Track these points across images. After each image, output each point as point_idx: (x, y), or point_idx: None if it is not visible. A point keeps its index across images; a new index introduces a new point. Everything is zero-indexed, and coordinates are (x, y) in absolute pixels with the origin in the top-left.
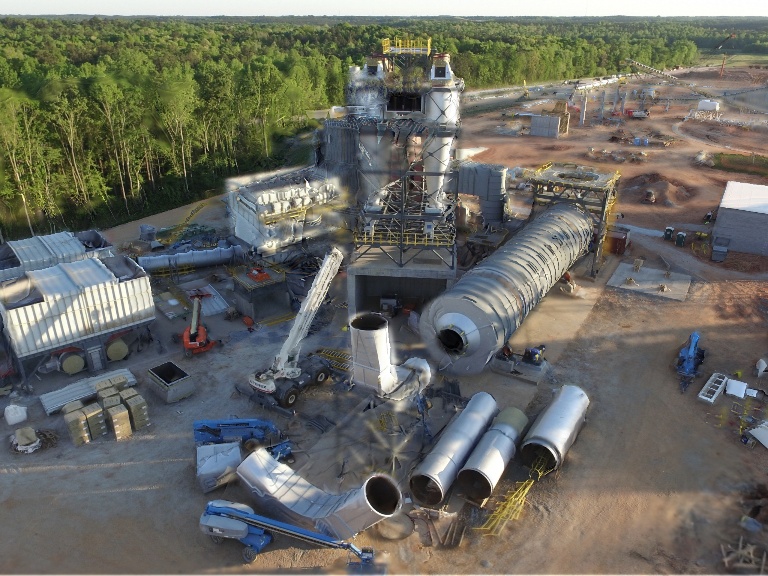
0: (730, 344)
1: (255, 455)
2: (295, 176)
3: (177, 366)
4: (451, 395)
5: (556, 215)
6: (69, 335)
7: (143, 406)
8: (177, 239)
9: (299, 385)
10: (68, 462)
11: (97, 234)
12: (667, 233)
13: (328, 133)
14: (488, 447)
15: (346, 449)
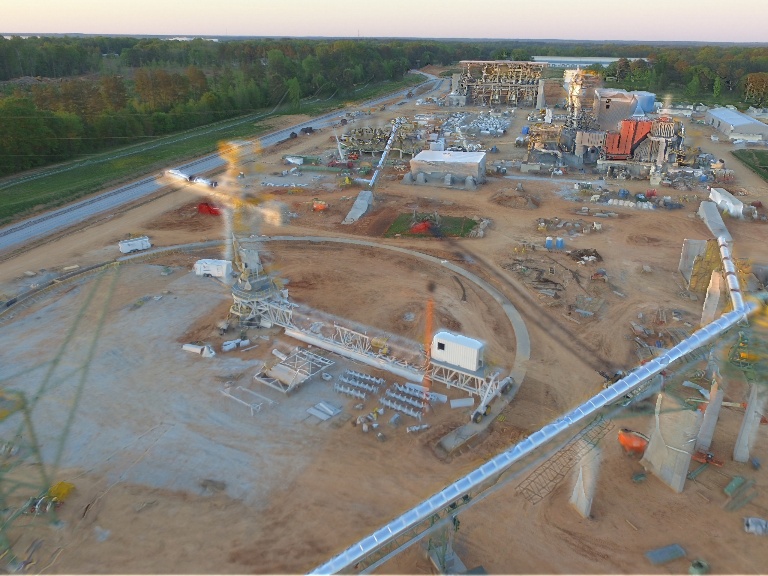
0: None
1: None
2: None
3: None
4: None
5: None
6: None
7: None
8: None
9: None
10: None
11: None
12: None
13: None
14: None
15: None
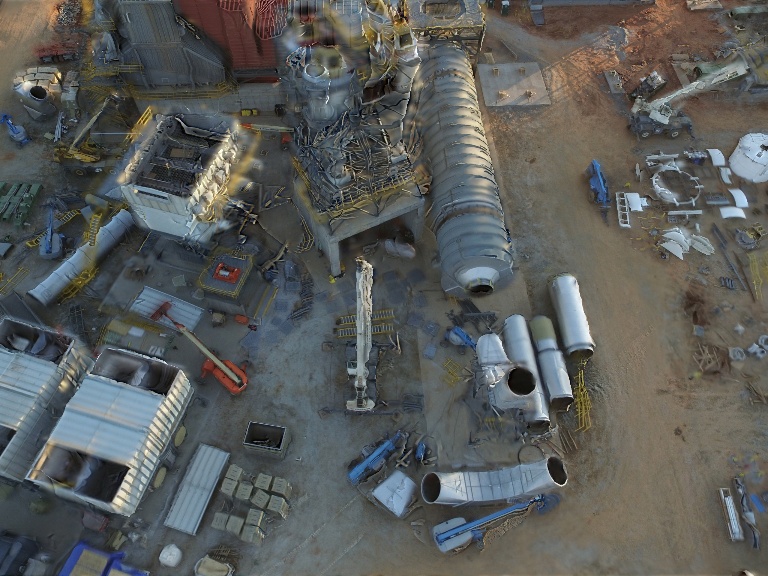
0: (606, 149)
1: (444, 487)
2: (97, 74)
3: (263, 424)
4: (474, 316)
5: (450, 71)
6: (153, 467)
7: (287, 485)
8: (16, 226)
9: (375, 381)
10: (270, 563)
11: (19, 325)
12: (490, 2)
13: (125, 12)
14: (556, 370)
15: (451, 415)
